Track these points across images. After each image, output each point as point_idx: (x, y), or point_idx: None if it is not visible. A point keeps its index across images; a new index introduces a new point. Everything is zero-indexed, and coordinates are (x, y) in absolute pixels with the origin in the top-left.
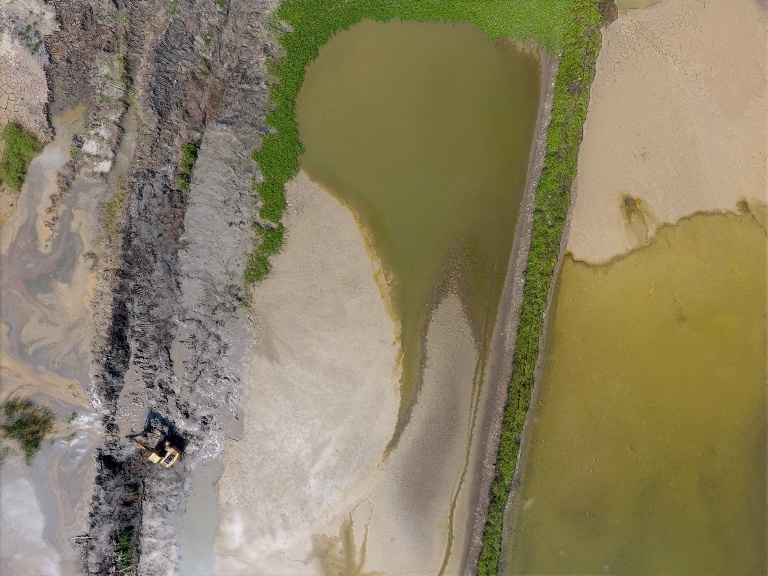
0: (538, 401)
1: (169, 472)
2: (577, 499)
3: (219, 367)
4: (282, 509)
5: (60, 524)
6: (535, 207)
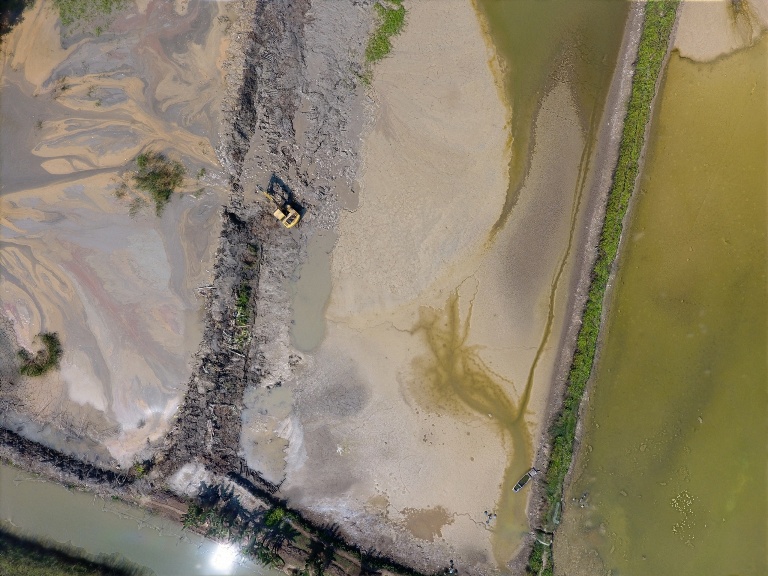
0: (640, 190)
1: (287, 238)
2: (673, 286)
3: (338, 141)
4: (392, 281)
5: (186, 275)
6: (647, 1)
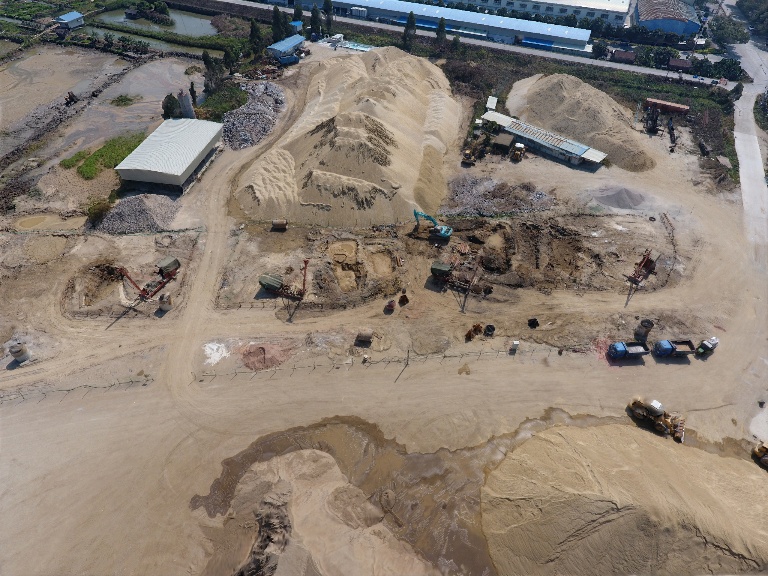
0: None
1: None
2: None
3: None
4: None
5: None
6: None
